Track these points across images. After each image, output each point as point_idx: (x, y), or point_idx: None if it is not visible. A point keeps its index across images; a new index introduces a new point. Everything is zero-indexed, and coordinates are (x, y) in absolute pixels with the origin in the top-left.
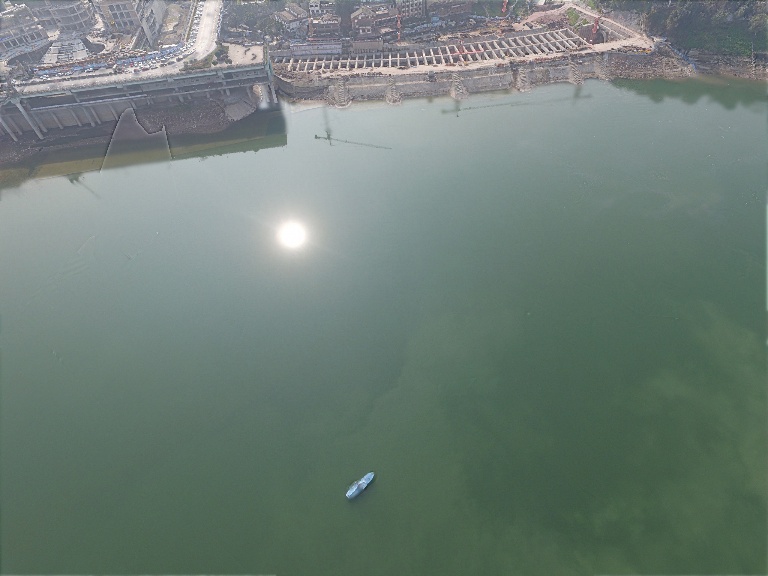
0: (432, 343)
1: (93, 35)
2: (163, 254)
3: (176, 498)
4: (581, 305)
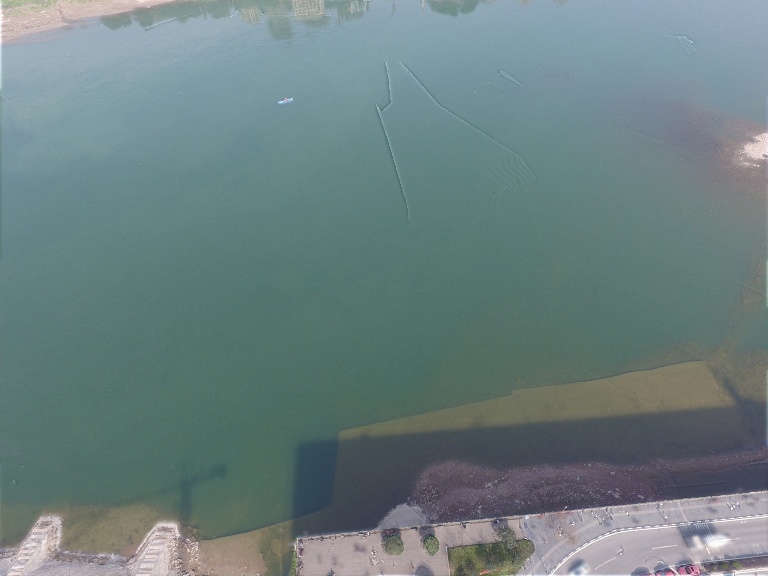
0: (219, 152)
1: None
2: None
3: (371, 93)
4: (101, 162)
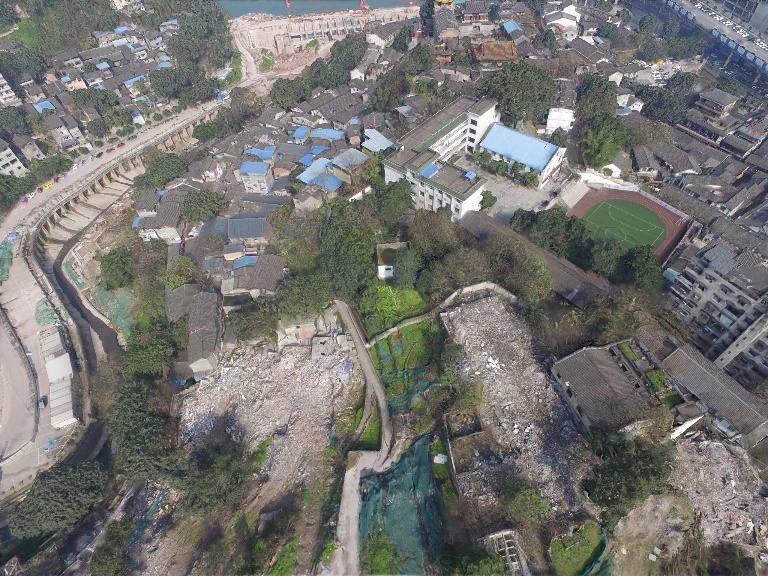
0: None
1: None
2: None
3: None
4: None
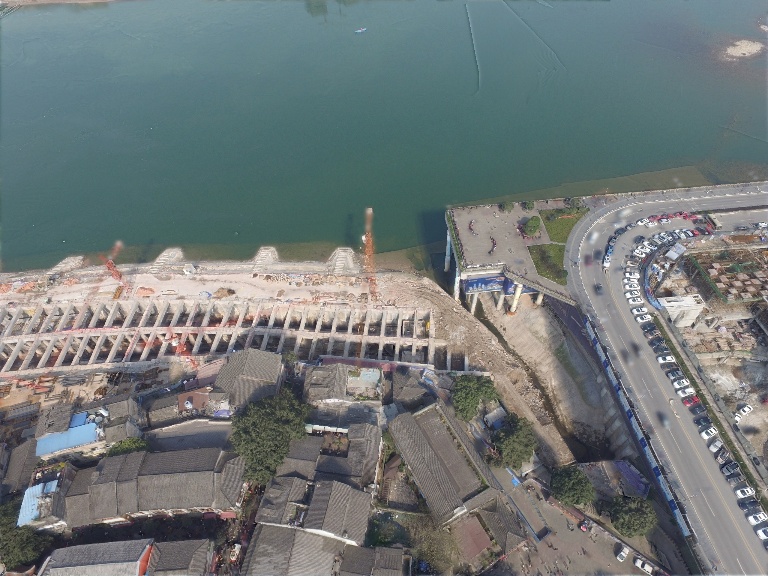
0: (317, 64)
1: None
2: None
3: None
4: (228, 72)
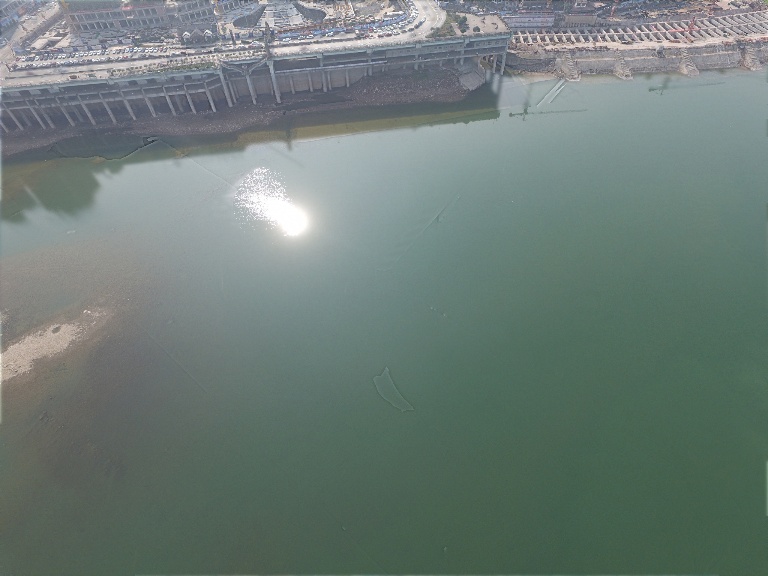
0: None
1: (305, 0)
2: (474, 218)
3: (661, 446)
4: None
